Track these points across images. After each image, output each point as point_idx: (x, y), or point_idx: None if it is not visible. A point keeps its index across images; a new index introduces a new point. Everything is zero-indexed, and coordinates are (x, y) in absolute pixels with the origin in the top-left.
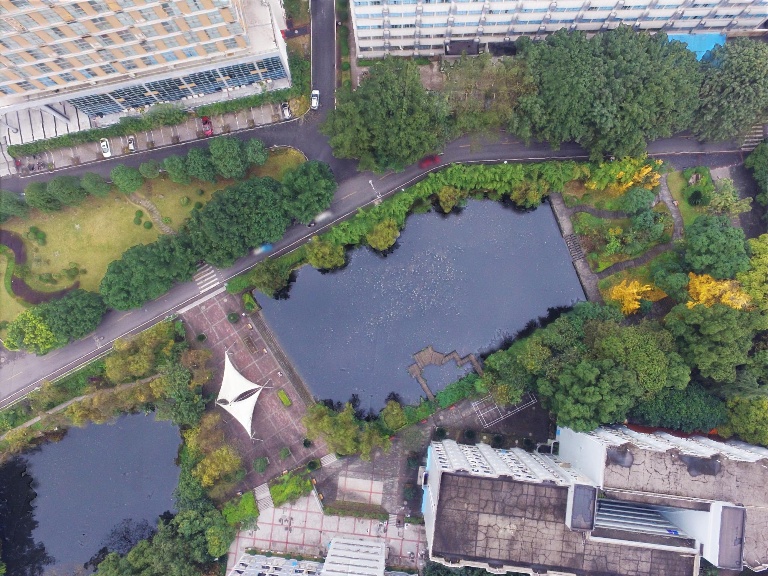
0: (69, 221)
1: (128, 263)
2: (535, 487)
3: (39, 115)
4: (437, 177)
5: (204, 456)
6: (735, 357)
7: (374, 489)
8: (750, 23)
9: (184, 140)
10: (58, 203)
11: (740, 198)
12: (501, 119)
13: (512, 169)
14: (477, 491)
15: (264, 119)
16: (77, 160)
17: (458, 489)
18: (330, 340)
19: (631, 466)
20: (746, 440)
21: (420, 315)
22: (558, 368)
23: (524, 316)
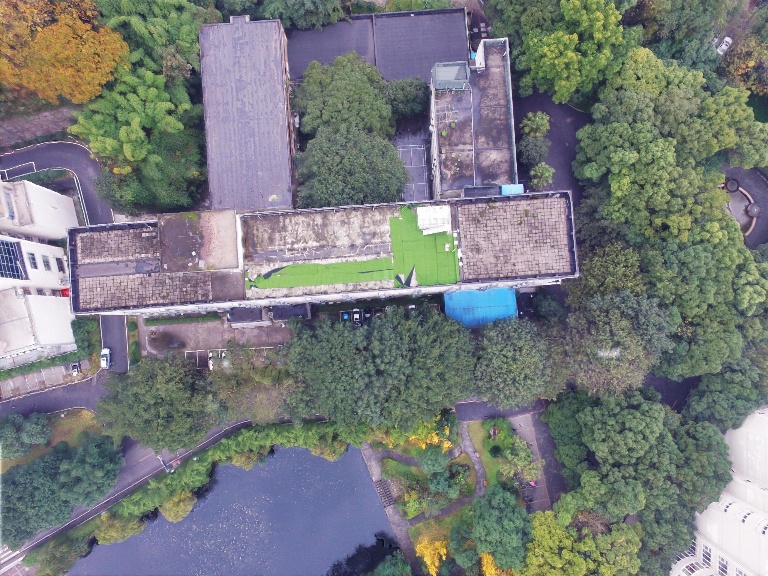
0: None
1: None
2: None
3: None
4: (229, 444)
5: None
6: None
7: None
8: None
9: None
10: None
11: None
12: None
13: (304, 435)
14: None
15: (55, 380)
16: None
17: None
18: None
19: None
20: None
21: (230, 571)
22: None
23: (353, 541)
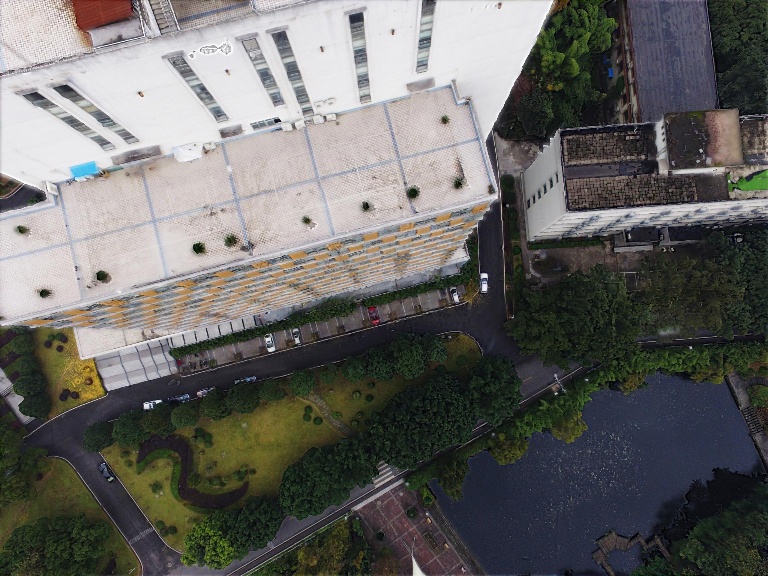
0: (235, 420)
1: (310, 473)
2: None
3: None
4: (620, 365)
5: None
6: None
7: None
8: None
9: (350, 330)
10: (229, 409)
11: None
12: None
13: (698, 355)
14: None
15: (431, 304)
16: (240, 356)
17: None
18: (510, 528)
19: None
20: None
21: (600, 498)
22: None
23: None
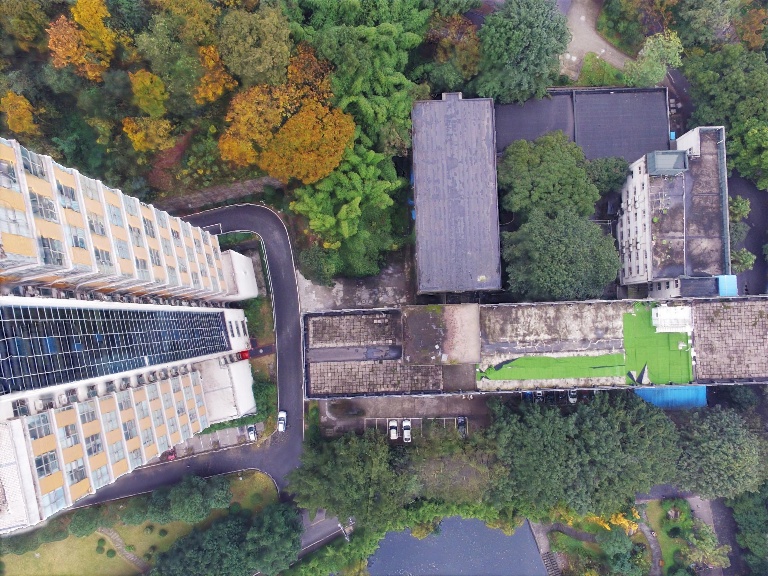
0: None
1: None
2: None
3: None
4: (409, 515)
5: None
6: None
7: None
8: None
9: None
10: None
11: None
12: None
13: (486, 509)
14: None
15: (229, 440)
16: None
17: None
18: None
19: None
20: None
21: None
22: None
23: None
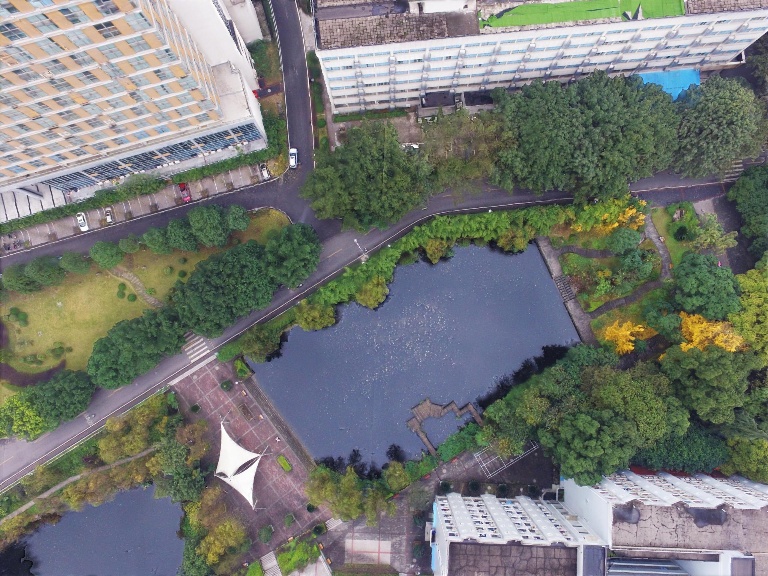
0: (50, 299)
1: (114, 341)
2: (544, 549)
3: (11, 194)
4: (422, 230)
5: (207, 530)
6: (732, 402)
7: (382, 549)
8: (723, 58)
9: (163, 208)
10: (37, 284)
11: (725, 231)
12: (483, 174)
13: (497, 218)
14: (486, 558)
15: (243, 181)
16: (54, 236)
17: (467, 558)
18: (326, 400)
19: (638, 522)
20: (749, 478)
21: (415, 368)
22: (558, 418)
23: (519, 356)
